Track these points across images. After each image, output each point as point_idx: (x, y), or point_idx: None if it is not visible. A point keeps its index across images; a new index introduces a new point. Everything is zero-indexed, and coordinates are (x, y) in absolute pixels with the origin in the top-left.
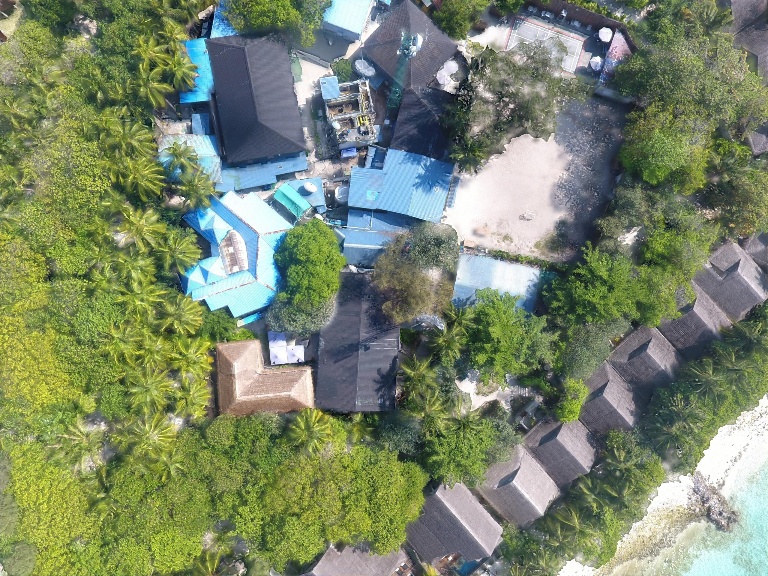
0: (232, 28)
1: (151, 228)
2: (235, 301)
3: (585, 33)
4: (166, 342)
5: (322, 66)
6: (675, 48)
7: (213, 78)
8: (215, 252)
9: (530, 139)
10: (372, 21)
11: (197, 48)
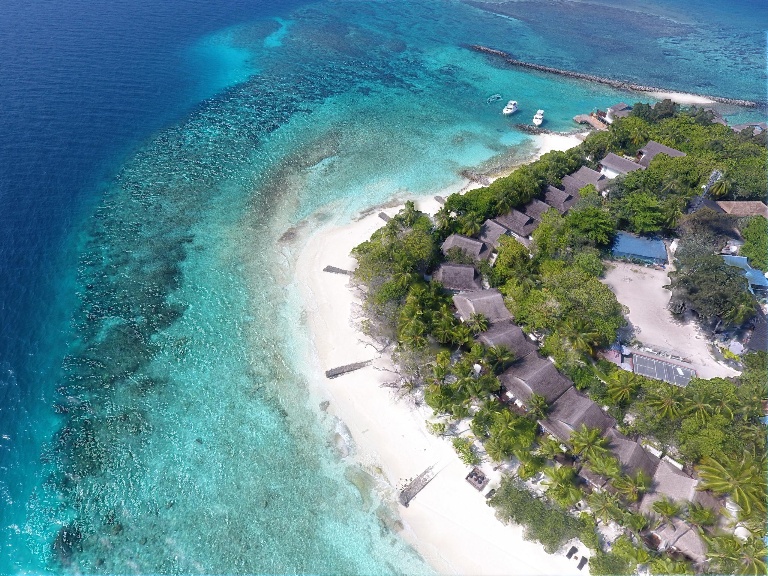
0: None
1: None
2: None
3: None
4: None
5: None
6: None
7: None
8: None
9: (646, 318)
10: None
11: None
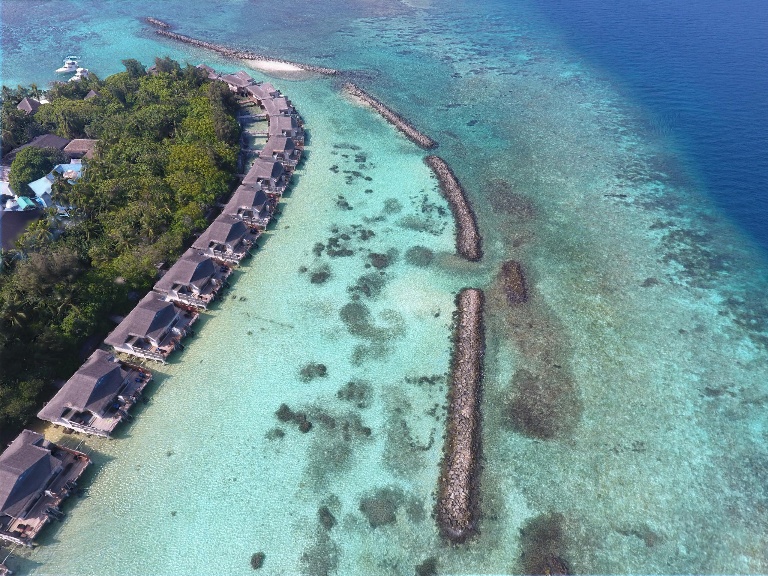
0: None
1: None
2: None
3: None
4: None
5: None
6: None
7: None
8: None
9: None
10: None
11: None
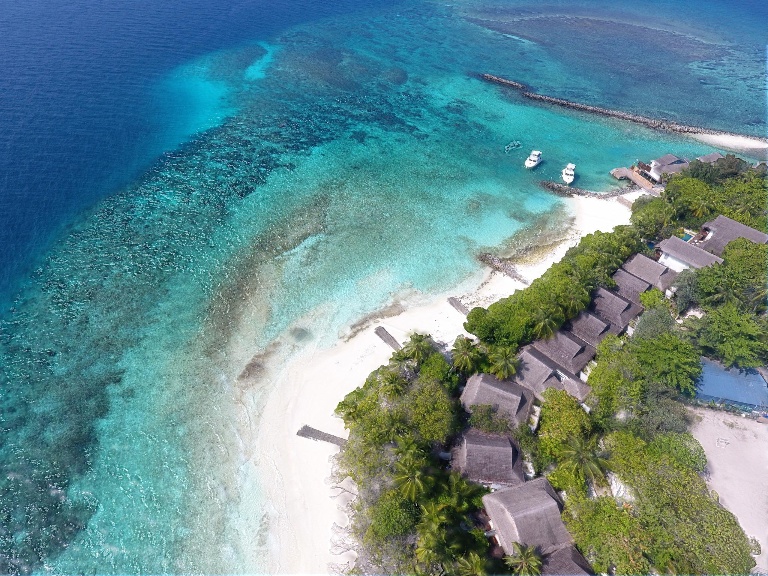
0: None
1: None
2: None
3: None
4: None
5: None
6: None
7: None
8: None
9: (762, 518)
10: None
11: None
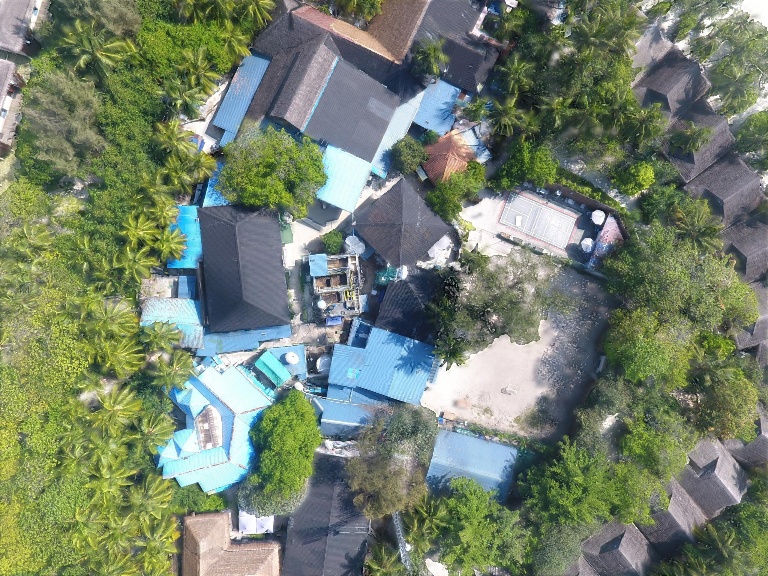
0: (225, 198)
1: (125, 413)
2: (206, 478)
3: (578, 210)
4: (132, 522)
5: (314, 229)
6: (663, 260)
7: (202, 247)
8: (190, 425)
9: None
10: (367, 186)
11: (189, 215)
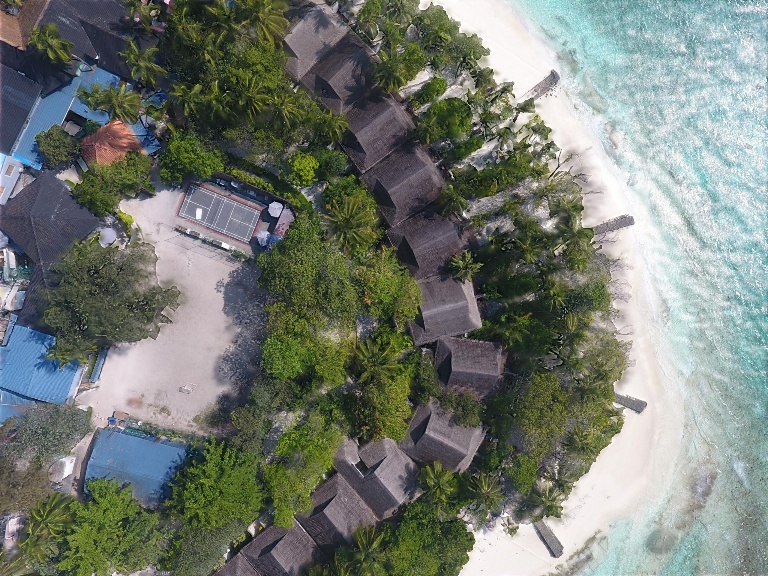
0: None
1: None
2: None
3: (263, 202)
4: None
5: None
6: (291, 253)
7: None
8: None
9: (197, 309)
10: None
11: None
